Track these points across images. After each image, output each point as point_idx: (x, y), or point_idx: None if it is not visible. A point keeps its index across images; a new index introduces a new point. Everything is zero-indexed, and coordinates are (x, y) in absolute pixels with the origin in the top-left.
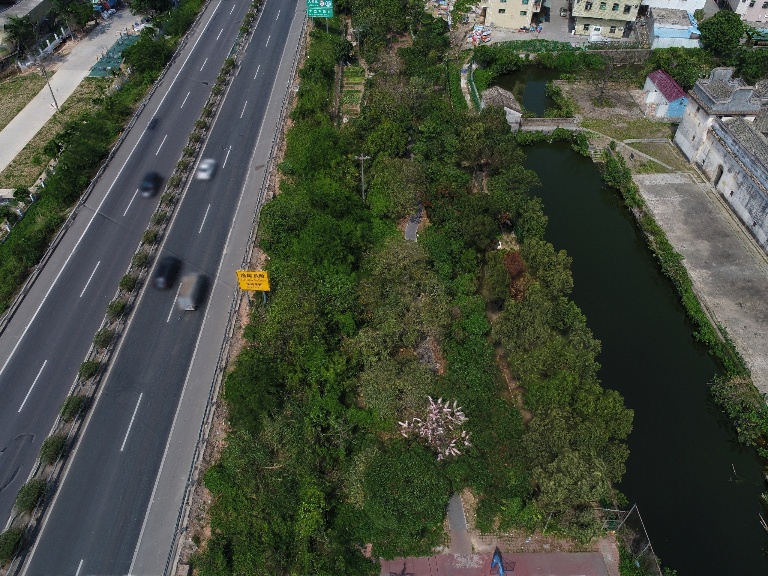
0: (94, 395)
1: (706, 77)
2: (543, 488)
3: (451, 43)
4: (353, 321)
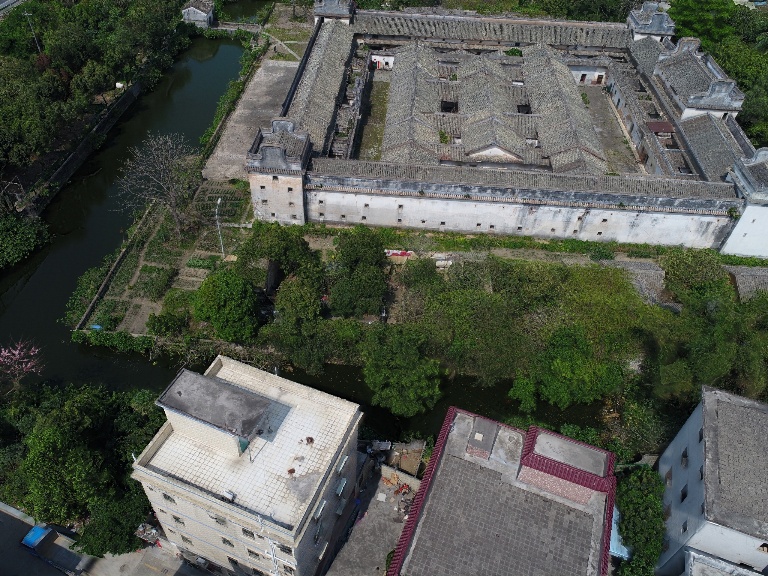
0: None
1: (390, 8)
2: None
3: None
4: None
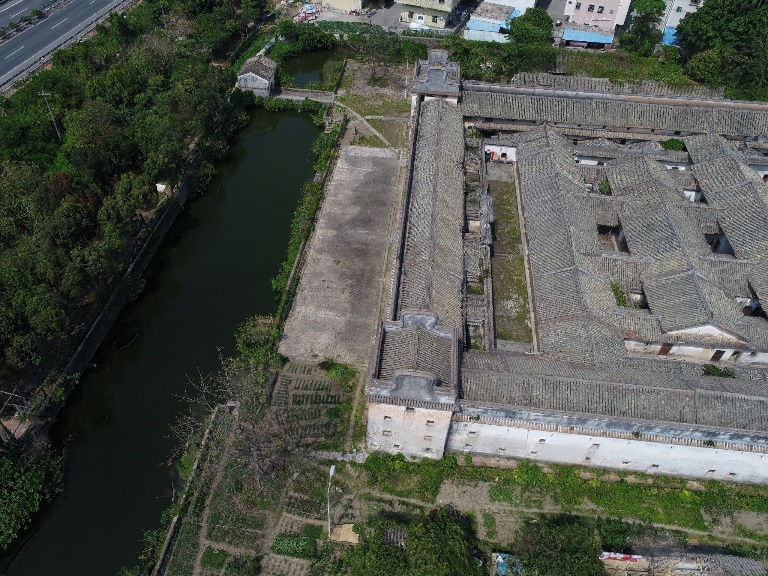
0: None
1: None
2: None
3: (277, 18)
4: None
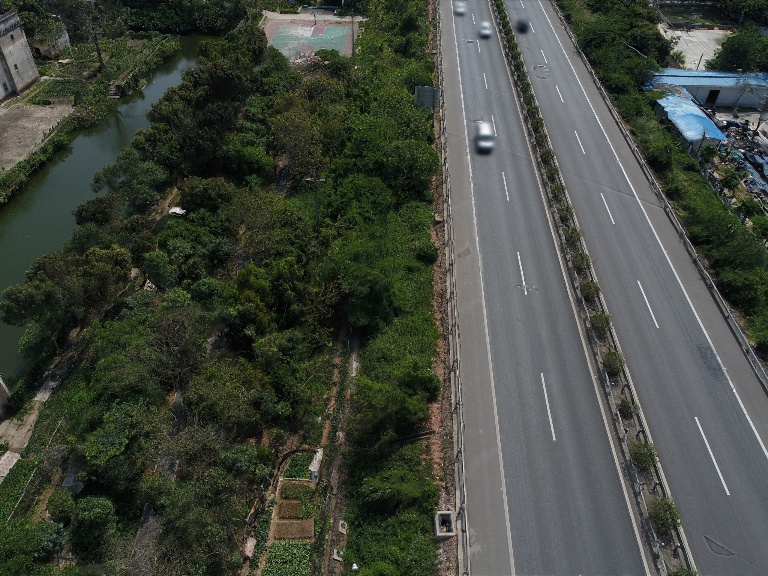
0: None
1: None
2: None
3: None
4: None
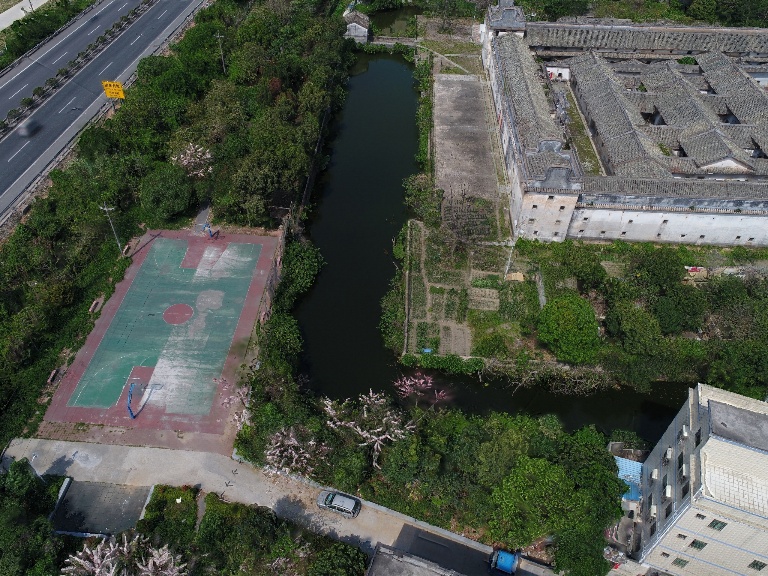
0: (1, 139)
1: None
2: (233, 182)
3: None
4: (177, 122)
